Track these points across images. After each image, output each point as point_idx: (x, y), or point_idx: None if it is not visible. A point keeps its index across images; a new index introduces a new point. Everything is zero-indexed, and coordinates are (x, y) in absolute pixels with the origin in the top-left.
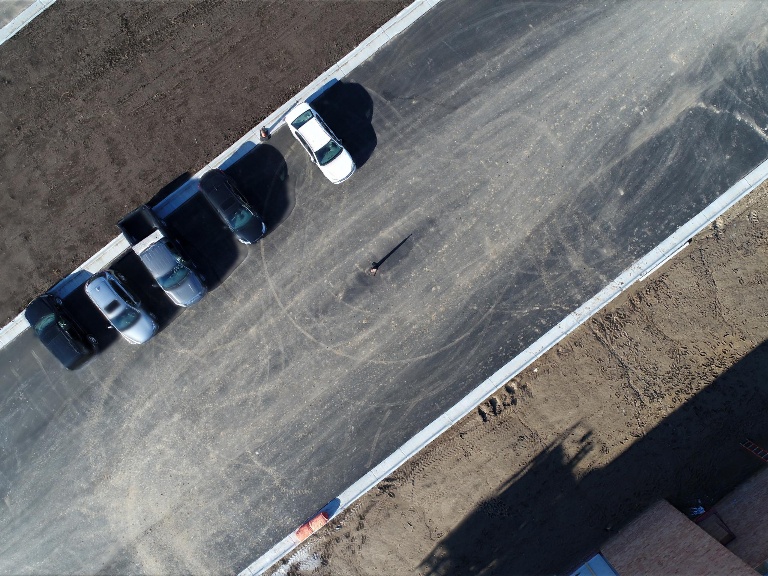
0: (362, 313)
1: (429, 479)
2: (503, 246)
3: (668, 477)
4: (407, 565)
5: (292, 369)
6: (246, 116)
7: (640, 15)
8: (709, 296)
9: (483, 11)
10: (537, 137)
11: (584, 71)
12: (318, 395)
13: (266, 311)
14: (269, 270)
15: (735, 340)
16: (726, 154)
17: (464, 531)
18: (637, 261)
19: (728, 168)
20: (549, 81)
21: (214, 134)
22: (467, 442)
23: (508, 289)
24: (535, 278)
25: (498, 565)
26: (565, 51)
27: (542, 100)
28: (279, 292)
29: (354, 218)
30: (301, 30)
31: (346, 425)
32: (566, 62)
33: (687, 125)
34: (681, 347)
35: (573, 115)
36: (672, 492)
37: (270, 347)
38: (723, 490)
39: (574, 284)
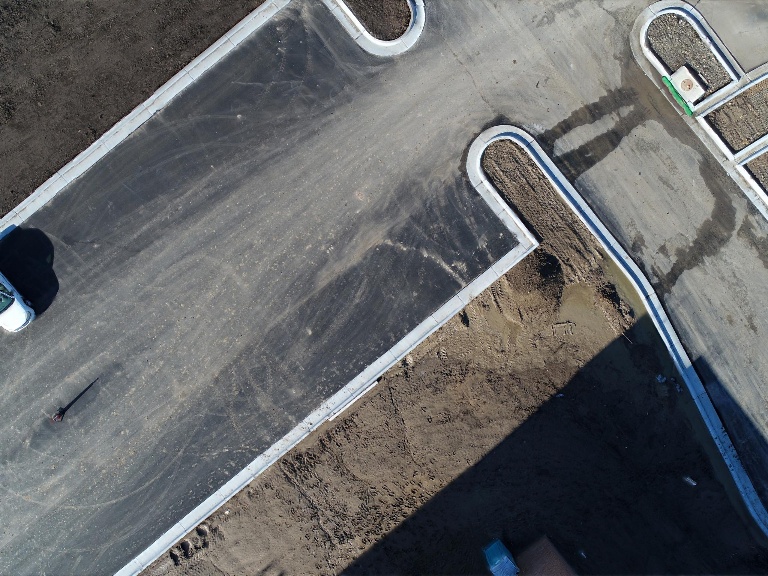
0: (50, 459)
1: None
2: (191, 388)
3: None
4: None
5: None
6: None
7: (323, 153)
8: (398, 435)
9: (163, 153)
10: (222, 278)
11: (268, 211)
12: (9, 542)
13: None
14: None
15: (424, 479)
16: (413, 291)
17: None
18: (326, 401)
19: (416, 305)
20: (232, 221)
21: None
22: None
23: (197, 431)
24: (224, 420)
25: None
26: (248, 191)
27: (226, 241)
28: None
29: (39, 364)
30: None
31: (37, 572)
32: (249, 202)
33: (374, 263)
34: (370, 488)
35: (258, 255)
36: None
37: None
38: None
39: (263, 425)
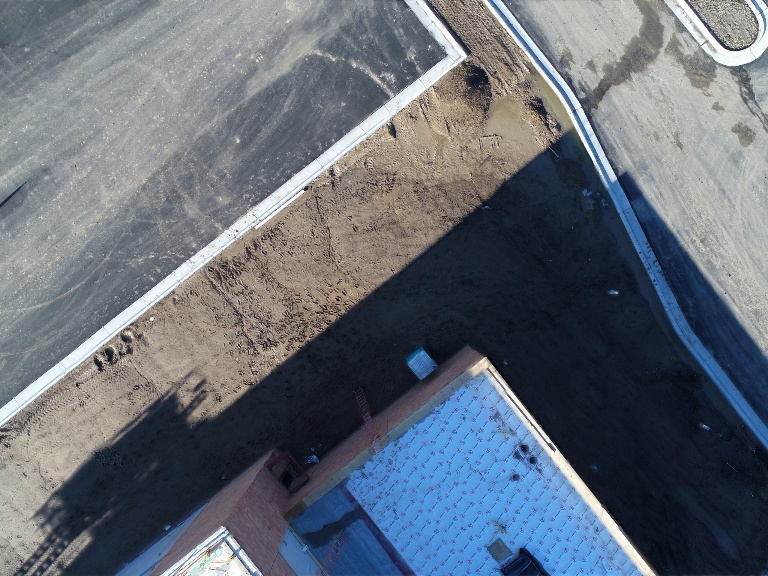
0: None
1: (44, 429)
2: (119, 194)
3: (281, 425)
4: (21, 516)
5: None
6: None
7: None
8: (323, 243)
9: None
10: (152, 85)
11: (198, 18)
12: None
13: None
14: None
15: (348, 287)
16: (341, 101)
17: (78, 481)
18: (252, 209)
19: (343, 115)
20: (163, 28)
21: None
22: (83, 392)
23: (124, 237)
24: (151, 226)
25: (113, 515)
26: None
27: (156, 48)
28: None
29: None
30: None
31: None
32: (180, 9)
33: (303, 72)
34: (294, 295)
35: (188, 63)
36: (285, 441)
37: None
38: (336, 438)
39: (189, 232)
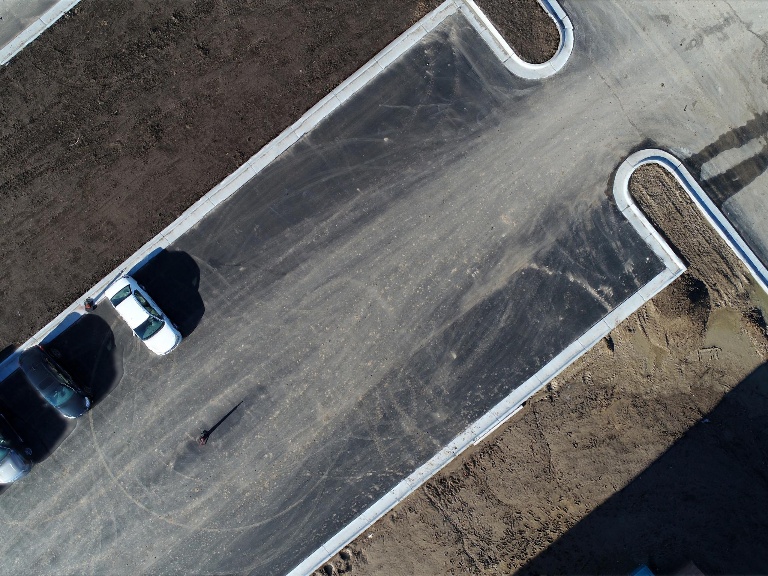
0: (194, 481)
1: None
2: (335, 411)
3: None
4: None
5: (125, 539)
6: (70, 287)
7: (469, 177)
8: (543, 460)
9: (309, 176)
10: (367, 301)
11: (414, 234)
12: (152, 564)
13: (97, 481)
14: (98, 440)
15: (570, 505)
16: (559, 316)
17: None
18: (470, 425)
19: (561, 330)
20: (378, 245)
21: (38, 306)
22: None
23: (341, 455)
24: (368, 444)
25: None
26: (394, 214)
27: (372, 264)
28: (109, 462)
29: (183, 386)
30: (123, 200)
31: None
32: (395, 225)
33: (519, 287)
34: (515, 512)
35: (403, 279)
36: None
37: (102, 517)
38: None
39: (407, 449)
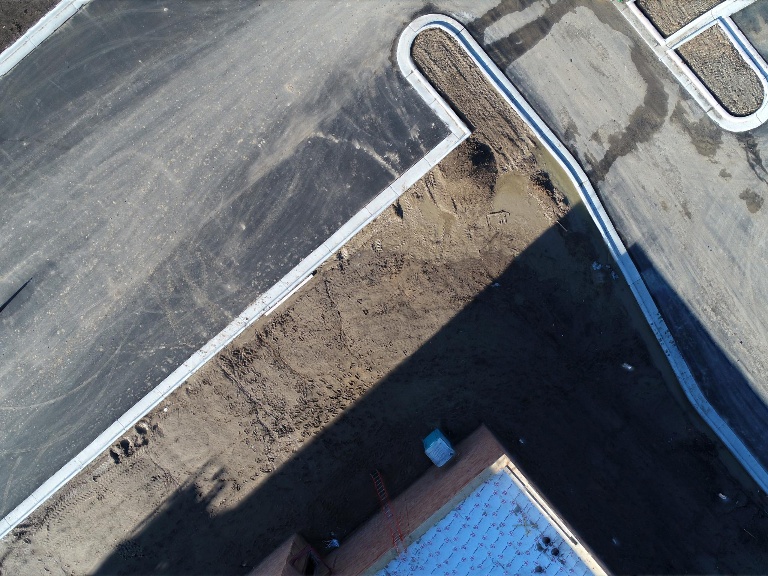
0: None
1: (64, 524)
2: (126, 286)
3: (300, 511)
4: None
5: None
6: None
7: (252, 46)
8: (334, 328)
9: (90, 48)
10: (154, 174)
11: (198, 105)
12: None
13: None
14: None
15: (361, 371)
16: (346, 184)
17: (100, 574)
18: (261, 296)
19: (349, 198)
20: (162, 117)
21: None
22: (100, 485)
23: (133, 329)
24: (160, 317)
25: None
26: (177, 86)
27: (157, 136)
28: None
29: None
30: None
31: None
32: (179, 97)
33: (306, 156)
34: (307, 380)
35: (189, 150)
36: (305, 526)
37: None
38: (355, 522)
39: (199, 321)
